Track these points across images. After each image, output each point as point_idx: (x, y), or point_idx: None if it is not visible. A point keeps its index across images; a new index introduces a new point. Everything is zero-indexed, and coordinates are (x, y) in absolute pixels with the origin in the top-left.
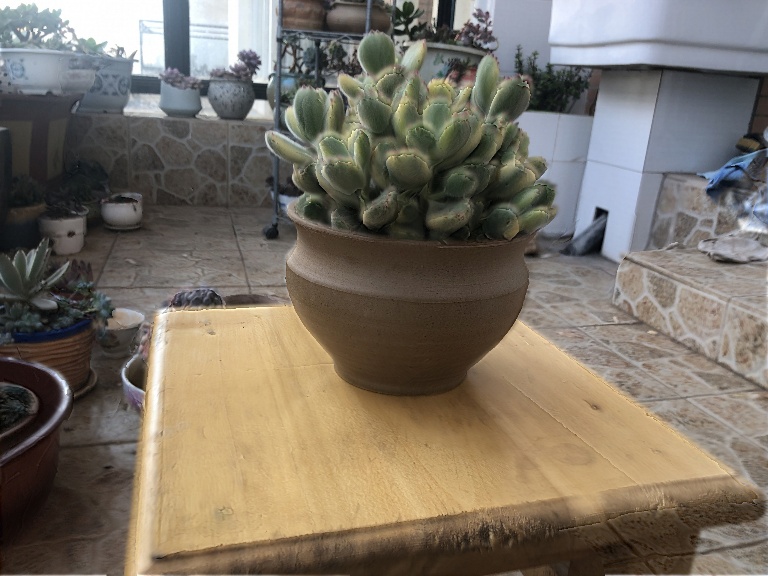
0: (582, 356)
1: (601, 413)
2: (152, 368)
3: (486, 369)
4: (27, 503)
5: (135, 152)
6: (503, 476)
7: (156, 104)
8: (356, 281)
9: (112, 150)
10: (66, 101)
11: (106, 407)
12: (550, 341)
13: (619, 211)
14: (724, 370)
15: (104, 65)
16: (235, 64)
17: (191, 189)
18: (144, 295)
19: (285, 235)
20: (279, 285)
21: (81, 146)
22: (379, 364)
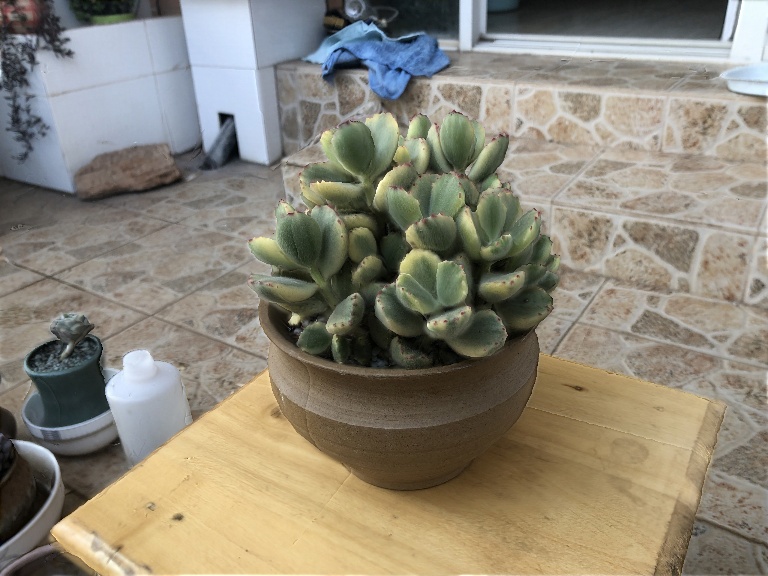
0: None
1: (590, 392)
2: None
3: None
4: None
5: None
6: (627, 509)
7: None
8: (446, 408)
9: None
10: None
11: None
12: (267, 272)
13: (245, 113)
14: None
15: None
16: None
17: None
18: None
19: None
20: None
21: None
22: None
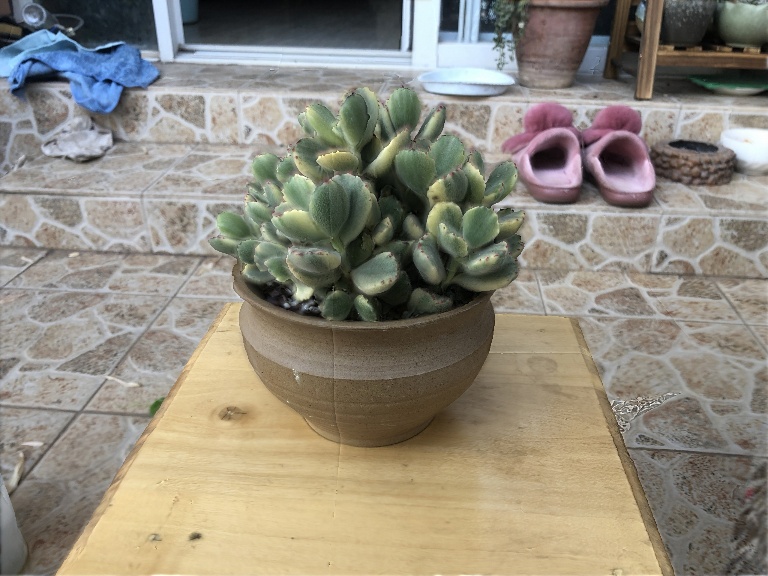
0: (53, 312)
1: None
2: None
3: None
4: None
5: None
6: (568, 404)
7: None
8: (461, 345)
9: None
10: None
11: None
12: (3, 316)
13: None
14: (165, 257)
15: None
16: None
17: None
18: None
19: None
20: None
21: None
22: None
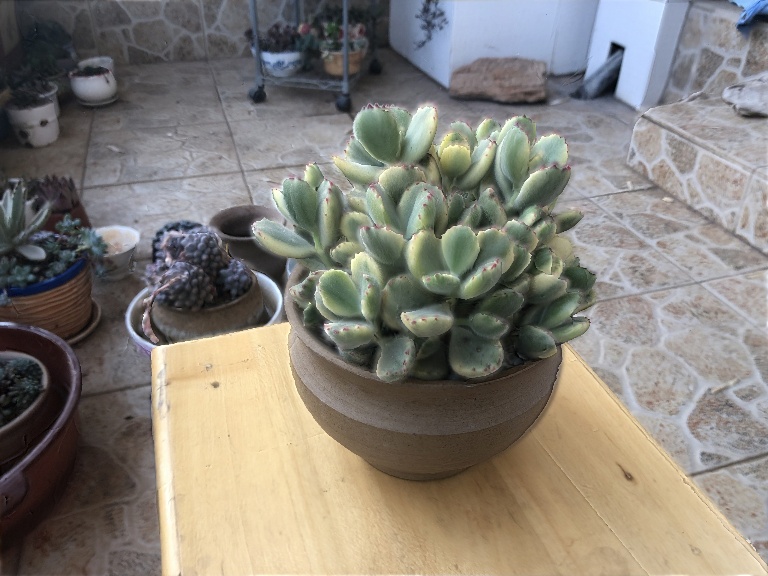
0: (595, 236)
1: (636, 487)
2: (158, 449)
3: None
4: (56, 484)
5: (96, 5)
6: None
7: None
8: (372, 410)
9: (70, 5)
10: None
11: (115, 343)
12: None
13: (637, 48)
14: (741, 244)
15: None
16: None
17: (165, 43)
18: (133, 193)
19: (273, 96)
20: (274, 167)
21: (34, 3)
22: None
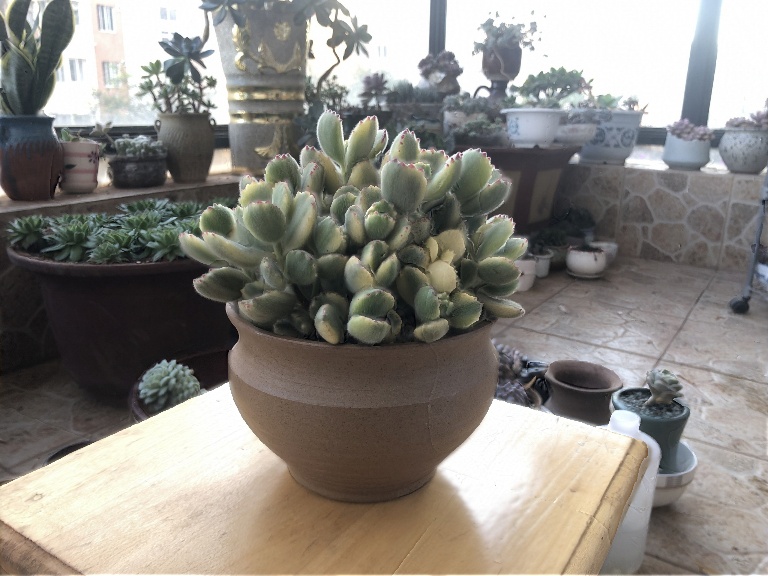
0: None
1: None
2: None
3: (439, 503)
4: None
5: (627, 203)
6: None
7: None
8: None
9: (604, 200)
10: (565, 153)
11: None
12: None
13: None
14: None
15: (604, 119)
16: (758, 112)
17: (678, 246)
18: (546, 342)
19: (761, 312)
20: (696, 366)
21: (578, 194)
22: None
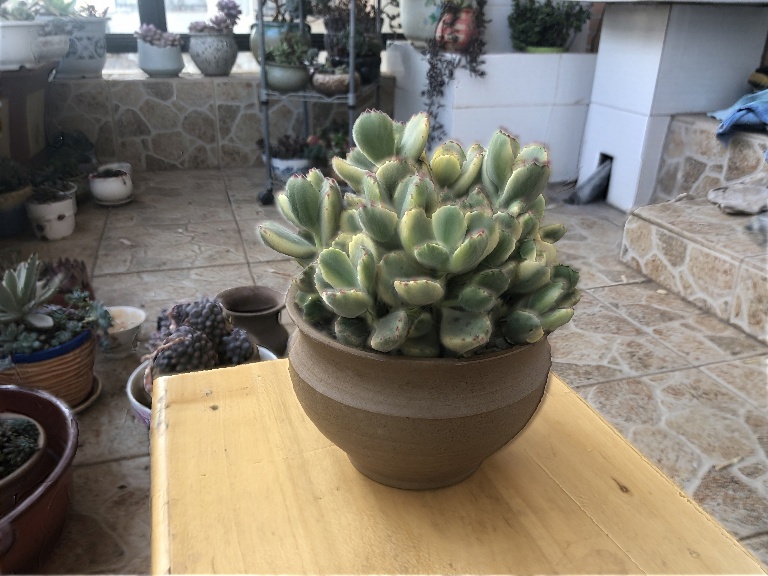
0: (591, 324)
1: (632, 498)
2: (154, 462)
3: None
4: (42, 545)
5: (119, 118)
6: None
7: (136, 65)
8: (366, 395)
9: (95, 117)
10: (42, 70)
11: (113, 416)
12: None
13: (624, 157)
14: (736, 332)
15: (77, 29)
16: (216, 16)
17: (181, 153)
18: (142, 281)
19: None
20: (279, 259)
21: (62, 115)
22: (395, 469)
